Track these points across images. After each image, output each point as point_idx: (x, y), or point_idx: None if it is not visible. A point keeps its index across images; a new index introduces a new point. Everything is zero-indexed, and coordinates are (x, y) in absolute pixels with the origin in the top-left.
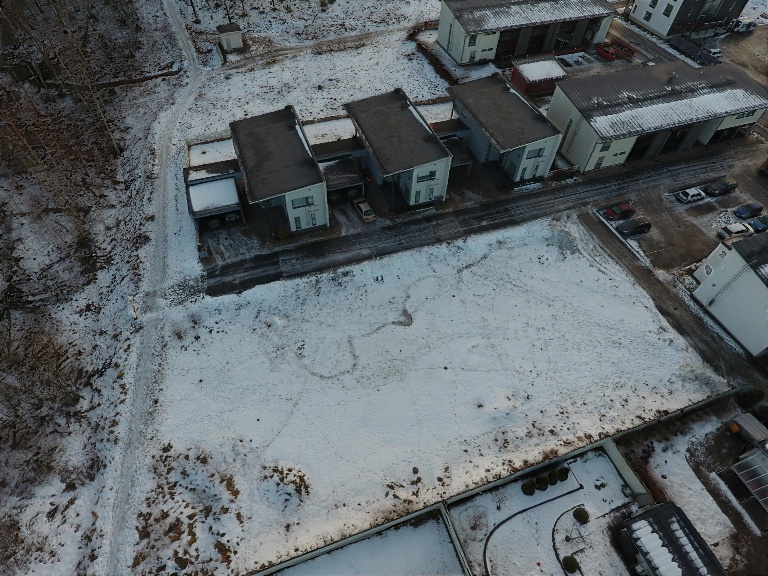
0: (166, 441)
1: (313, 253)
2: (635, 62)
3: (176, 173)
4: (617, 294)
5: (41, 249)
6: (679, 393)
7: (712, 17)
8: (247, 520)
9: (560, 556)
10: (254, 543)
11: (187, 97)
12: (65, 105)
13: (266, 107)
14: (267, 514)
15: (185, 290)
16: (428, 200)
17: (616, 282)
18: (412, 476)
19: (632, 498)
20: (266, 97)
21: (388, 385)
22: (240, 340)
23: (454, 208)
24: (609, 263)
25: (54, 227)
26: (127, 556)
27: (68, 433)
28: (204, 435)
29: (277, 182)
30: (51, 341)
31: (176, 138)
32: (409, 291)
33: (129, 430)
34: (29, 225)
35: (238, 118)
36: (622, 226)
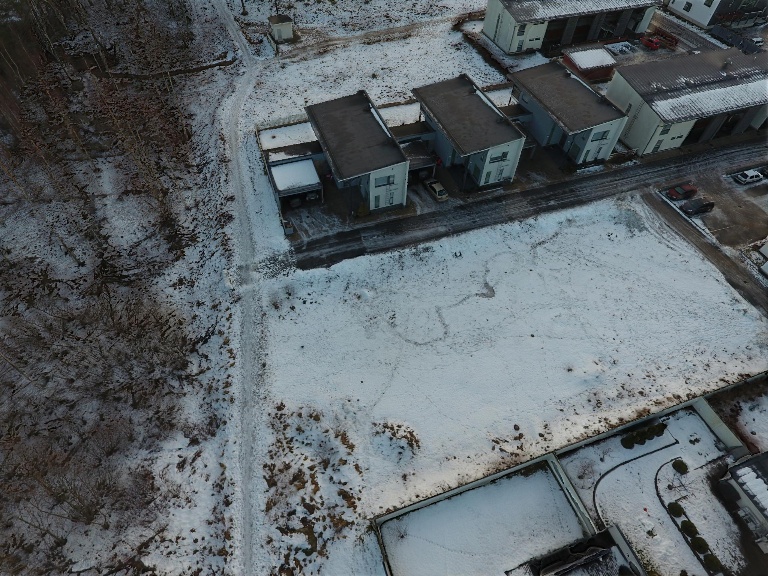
0: (278, 400)
1: (392, 230)
2: (679, 51)
3: (248, 156)
4: (688, 268)
5: (127, 228)
6: (758, 359)
7: (752, 7)
8: (365, 471)
9: (665, 502)
10: (375, 491)
11: (246, 85)
12: (128, 93)
13: (324, 95)
14: (383, 465)
15: (276, 264)
16: (496, 181)
17: (685, 257)
18: (514, 432)
19: (726, 452)
20: (323, 85)
21: (480, 351)
22: (333, 310)
23: (521, 189)
24: (677, 240)
25: (136, 207)
26: (260, 501)
27: (183, 394)
28: (313, 395)
29: (362, 161)
30: (151, 312)
31: (242, 124)
32: (488, 266)
33: (243, 390)
34: (112, 206)
35: (299, 105)
36: (686, 205)
